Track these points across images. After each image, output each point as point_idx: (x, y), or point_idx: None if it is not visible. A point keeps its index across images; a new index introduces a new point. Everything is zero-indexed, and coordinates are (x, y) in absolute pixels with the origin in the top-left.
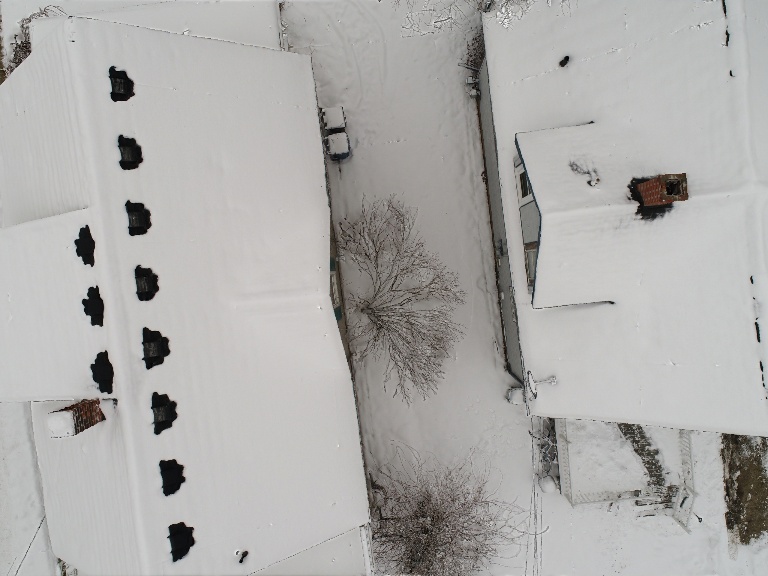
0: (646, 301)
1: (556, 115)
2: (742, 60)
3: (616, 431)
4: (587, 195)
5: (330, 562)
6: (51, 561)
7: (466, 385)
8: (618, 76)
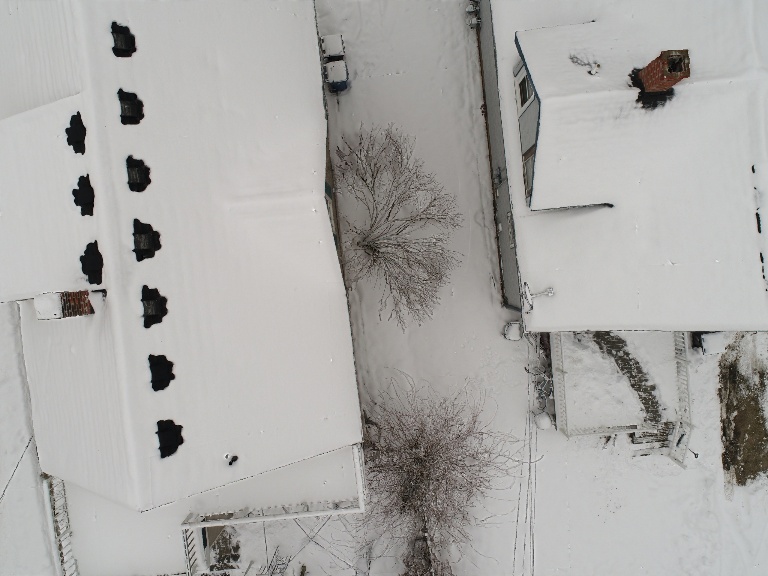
0: (645, 201)
1: (557, 18)
2: None
3: (613, 366)
4: (587, 83)
5: (322, 484)
6: (40, 498)
7: (462, 321)
8: None
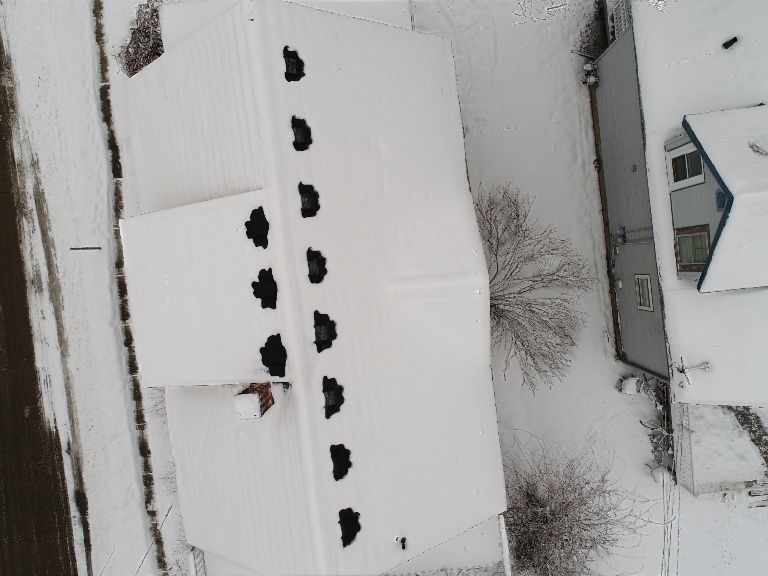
0: None
1: (718, 98)
2: None
3: (733, 421)
4: None
5: (462, 551)
6: (150, 551)
7: (576, 375)
8: None
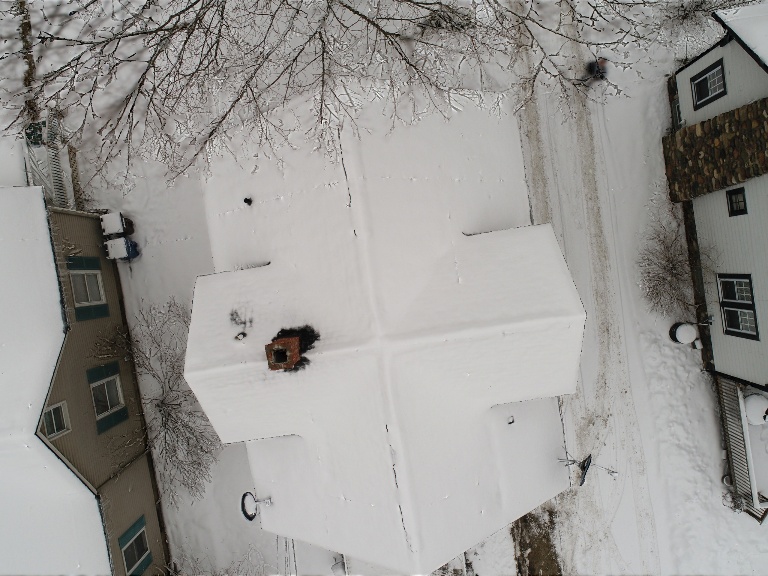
0: (322, 436)
1: (248, 251)
2: (360, 222)
3: None
4: (231, 350)
5: None
6: None
7: None
8: (283, 222)
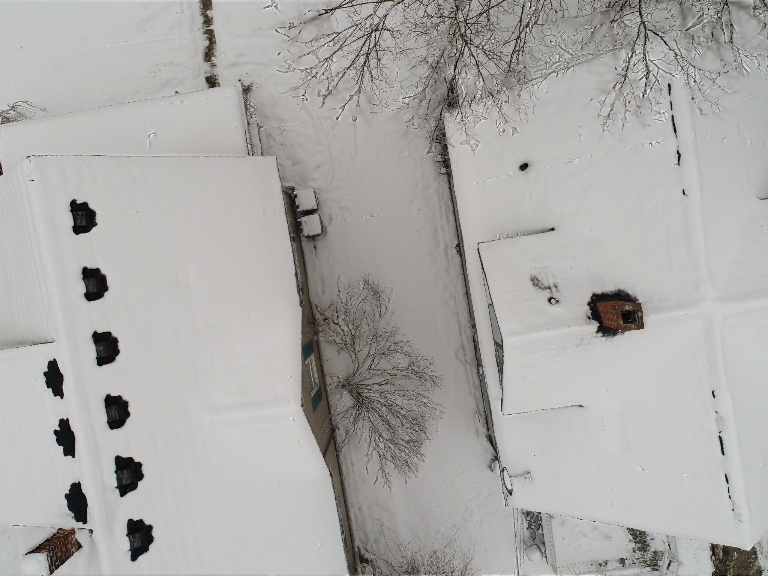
0: (613, 406)
1: (518, 218)
2: (694, 180)
3: None
4: (547, 315)
5: None
6: None
7: (449, 456)
8: (576, 186)
